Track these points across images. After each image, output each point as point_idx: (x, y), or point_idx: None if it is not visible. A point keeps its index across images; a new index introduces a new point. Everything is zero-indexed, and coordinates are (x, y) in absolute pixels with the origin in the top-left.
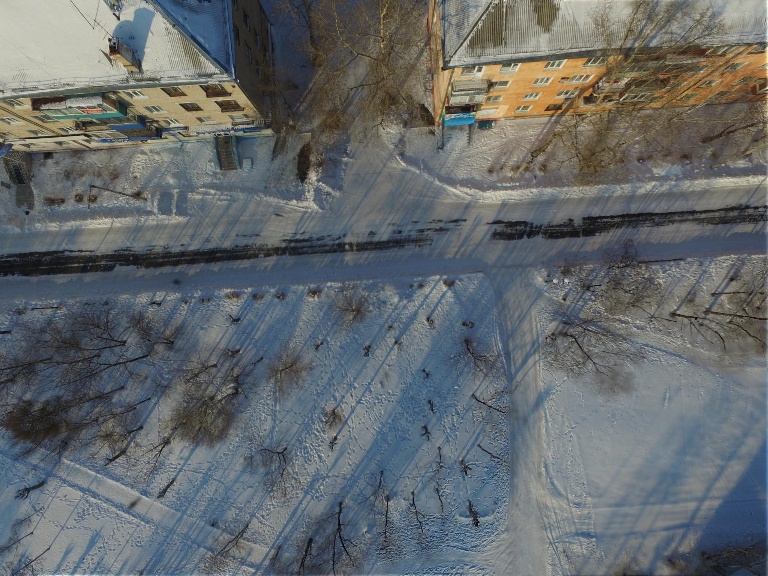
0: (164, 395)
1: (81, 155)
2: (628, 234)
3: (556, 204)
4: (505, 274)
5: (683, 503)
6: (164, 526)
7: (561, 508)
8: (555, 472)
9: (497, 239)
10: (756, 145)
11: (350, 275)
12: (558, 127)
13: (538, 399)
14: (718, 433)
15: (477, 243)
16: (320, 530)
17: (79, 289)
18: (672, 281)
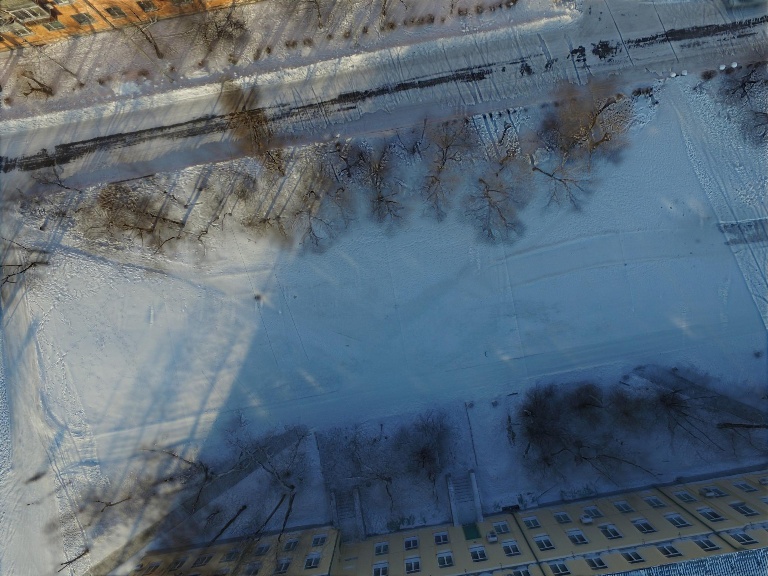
0: None
1: None
2: (101, 157)
3: (28, 136)
4: None
5: (181, 419)
6: None
7: (63, 439)
8: (51, 403)
9: None
10: (213, 54)
11: None
12: (21, 60)
13: (29, 332)
14: (205, 344)
15: None
16: None
17: None
18: (144, 198)
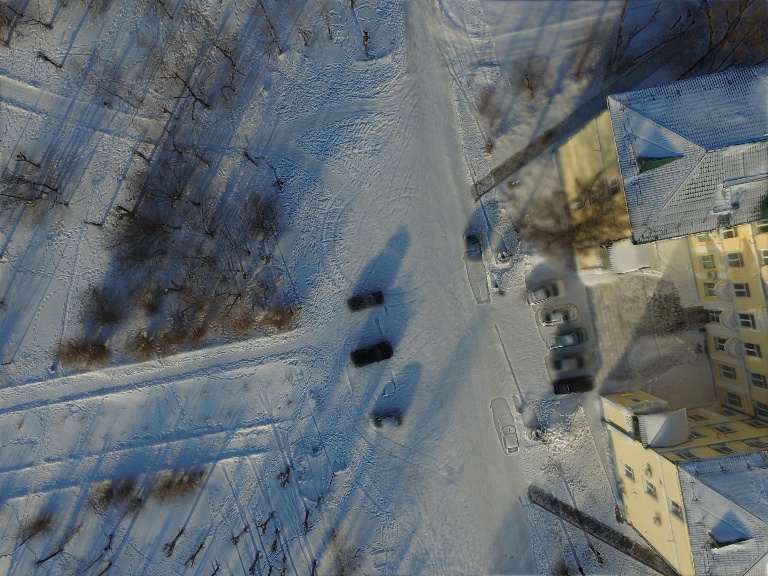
0: None
1: None
2: None
3: None
4: None
5: (584, 17)
6: (57, 115)
7: (460, 41)
8: (449, 3)
9: None
10: None
11: None
12: None
13: None
14: None
15: None
16: (216, 95)
17: None
18: None
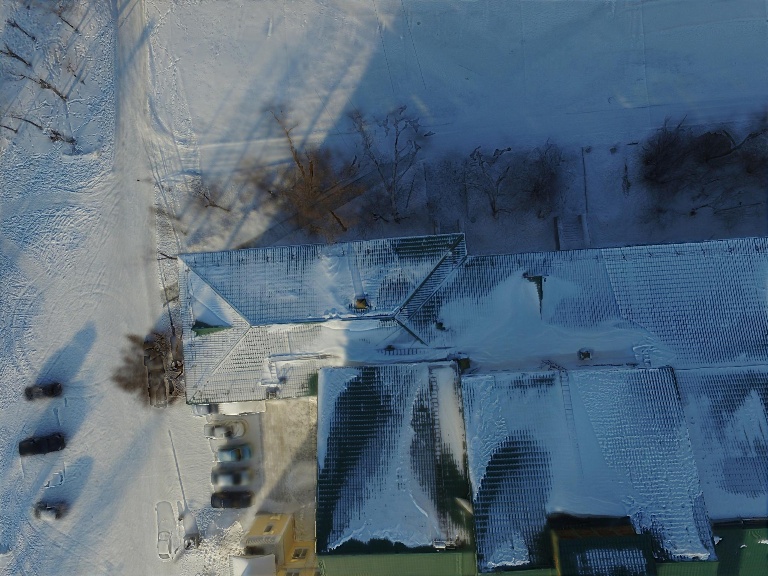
0: None
1: None
2: None
3: None
4: None
5: None
6: None
7: (167, 146)
8: (159, 108)
9: None
10: None
11: None
12: None
13: (143, 34)
14: (322, 62)
15: None
16: None
17: None
18: None
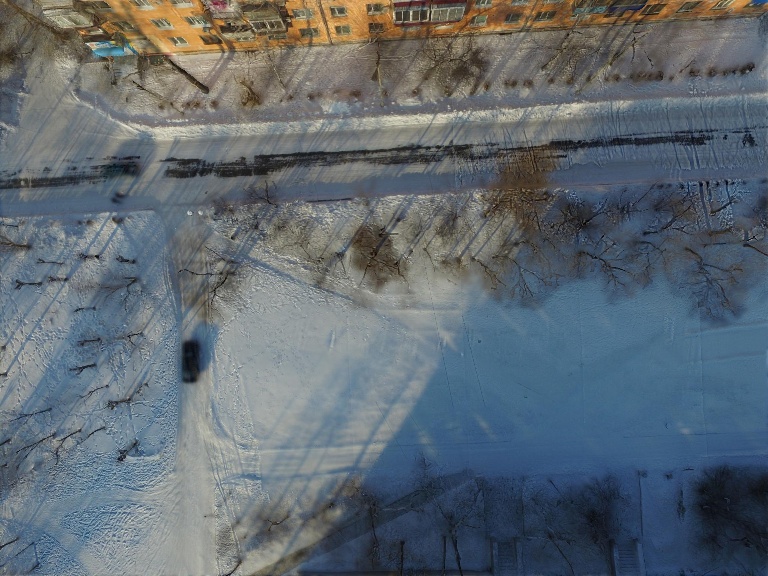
0: None
1: None
2: (300, 173)
3: (228, 142)
4: (177, 212)
5: (348, 446)
6: None
7: (228, 449)
8: (221, 412)
9: (170, 177)
10: (427, 83)
11: (24, 211)
12: (231, 63)
13: (207, 339)
14: (383, 376)
15: (150, 180)
16: None
17: None
18: (340, 221)
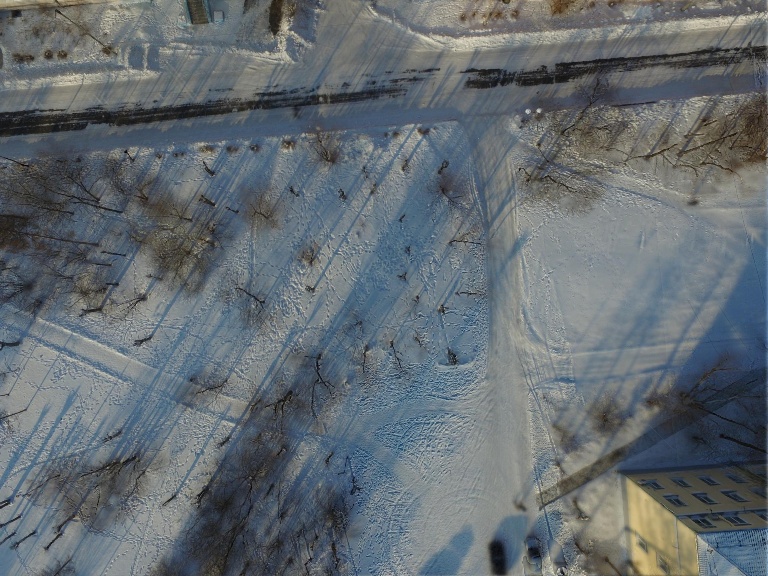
0: (139, 251)
1: (50, 12)
2: None
3: (529, 51)
4: (480, 122)
5: (661, 345)
6: (142, 384)
7: (540, 354)
8: (533, 318)
9: (471, 87)
10: None
11: (324, 127)
12: None
13: (515, 246)
14: (694, 274)
15: (451, 92)
16: (300, 382)
17: (51, 148)
18: (645, 124)
